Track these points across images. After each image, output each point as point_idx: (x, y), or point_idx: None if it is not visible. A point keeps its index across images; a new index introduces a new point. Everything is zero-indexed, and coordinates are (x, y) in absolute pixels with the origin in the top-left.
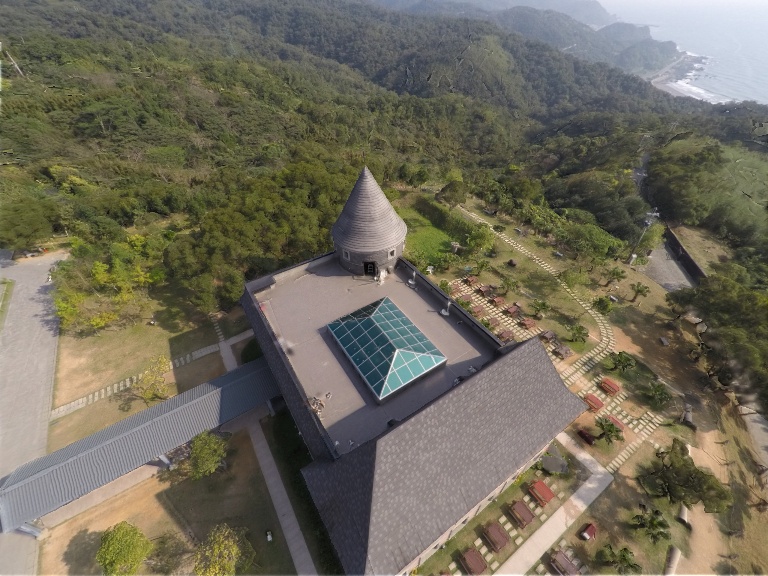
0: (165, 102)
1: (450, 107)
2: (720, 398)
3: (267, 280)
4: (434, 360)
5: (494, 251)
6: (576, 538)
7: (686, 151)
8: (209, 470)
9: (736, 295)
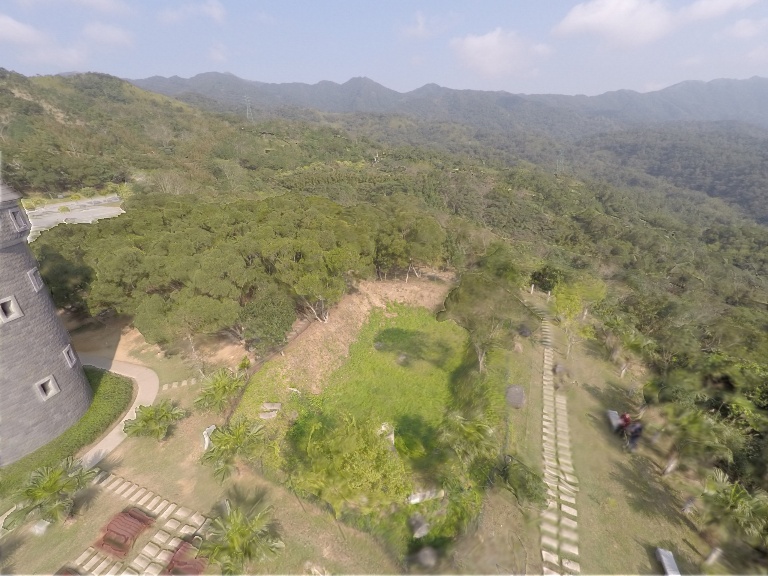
0: (440, 188)
1: None
2: None
3: None
4: None
5: (446, 548)
6: None
7: None
8: None
9: None
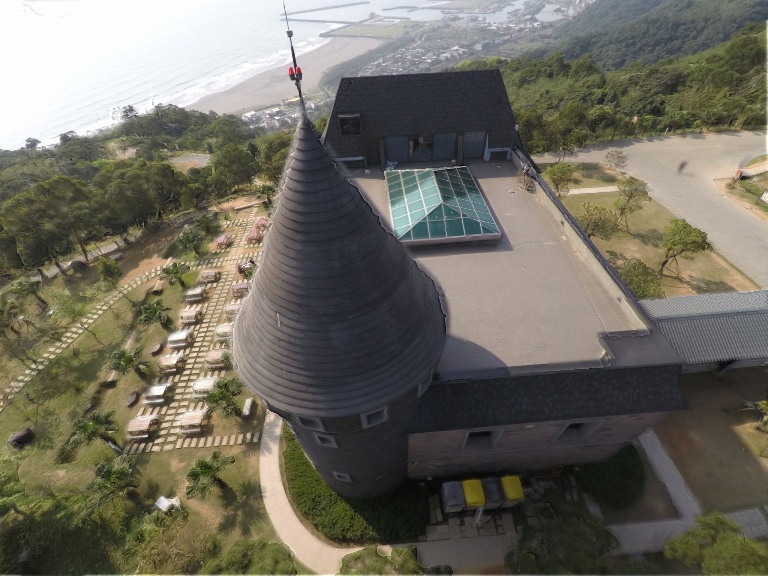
0: None
1: None
2: None
3: (624, 351)
4: None
5: None
6: None
7: None
8: None
9: None
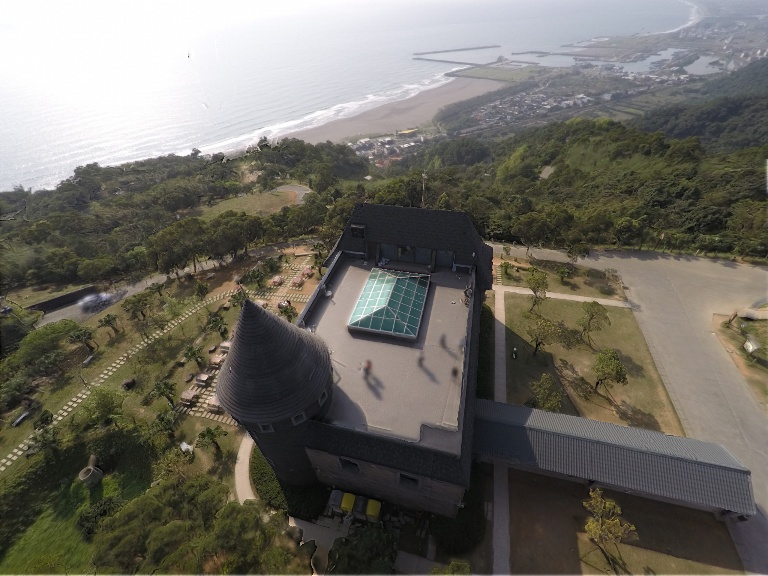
0: None
1: None
2: None
3: (430, 437)
4: None
5: None
6: None
7: None
8: None
9: None
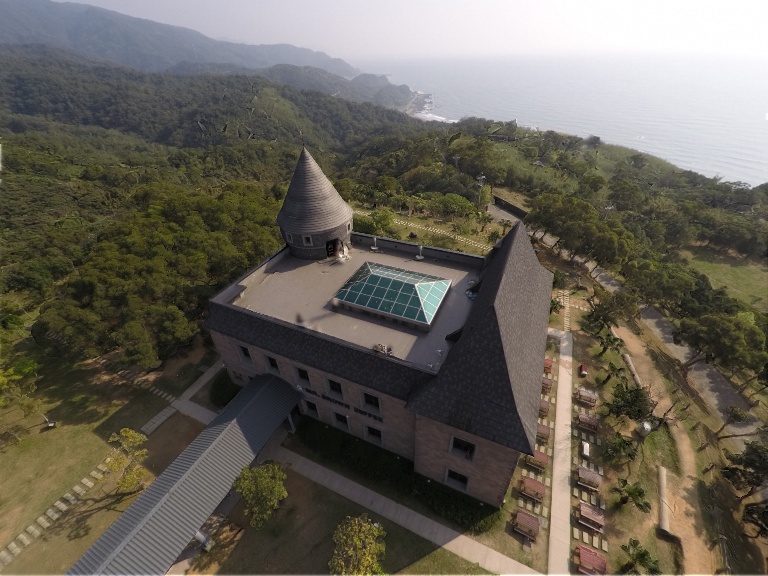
0: None
1: (259, 151)
2: (584, 269)
3: (235, 289)
4: (445, 284)
5: (393, 232)
6: (580, 379)
7: (468, 142)
8: (276, 502)
9: (561, 202)
